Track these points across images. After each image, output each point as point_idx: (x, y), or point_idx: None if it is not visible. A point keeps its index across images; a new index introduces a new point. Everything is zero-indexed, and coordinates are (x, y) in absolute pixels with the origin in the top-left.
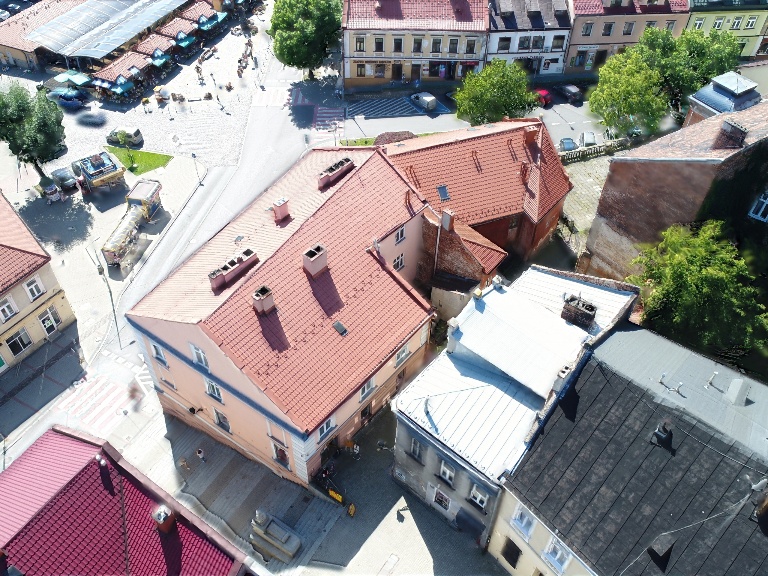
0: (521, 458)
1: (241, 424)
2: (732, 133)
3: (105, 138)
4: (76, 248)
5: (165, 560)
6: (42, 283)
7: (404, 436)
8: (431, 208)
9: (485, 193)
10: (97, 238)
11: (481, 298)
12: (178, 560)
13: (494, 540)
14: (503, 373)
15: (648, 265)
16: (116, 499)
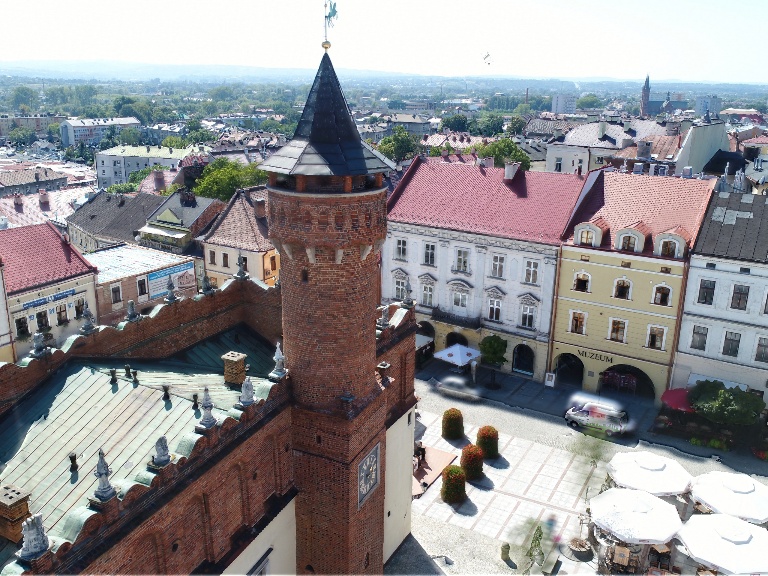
0: None
1: None
2: (194, 163)
3: None
4: None
5: None
6: None
7: None
8: None
9: None
10: None
11: None
12: None
13: None
14: None
15: None
16: None
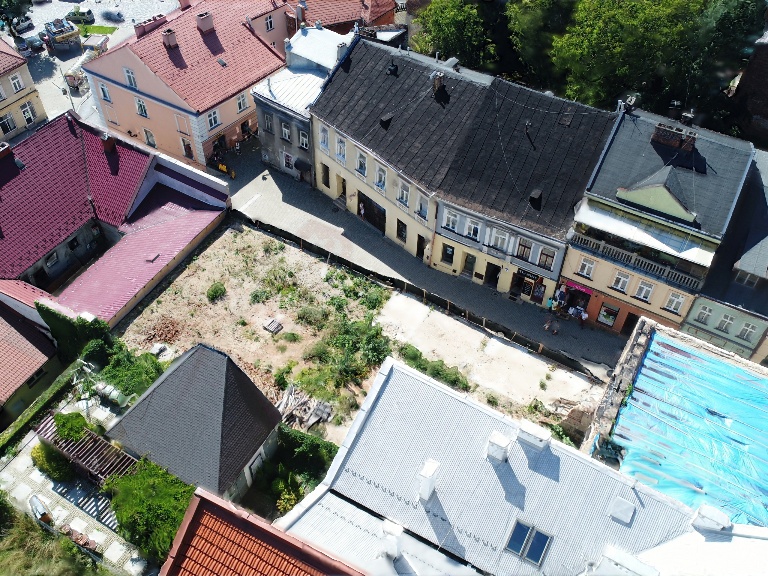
0: (319, 96)
1: (162, 134)
2: None
3: (64, 18)
4: (45, 82)
5: (110, 167)
6: (22, 80)
7: (260, 115)
8: (289, 5)
9: (333, 6)
10: (61, 76)
11: (306, 29)
12: (117, 165)
13: (317, 174)
14: (317, 67)
15: (422, 23)
16: (79, 140)
